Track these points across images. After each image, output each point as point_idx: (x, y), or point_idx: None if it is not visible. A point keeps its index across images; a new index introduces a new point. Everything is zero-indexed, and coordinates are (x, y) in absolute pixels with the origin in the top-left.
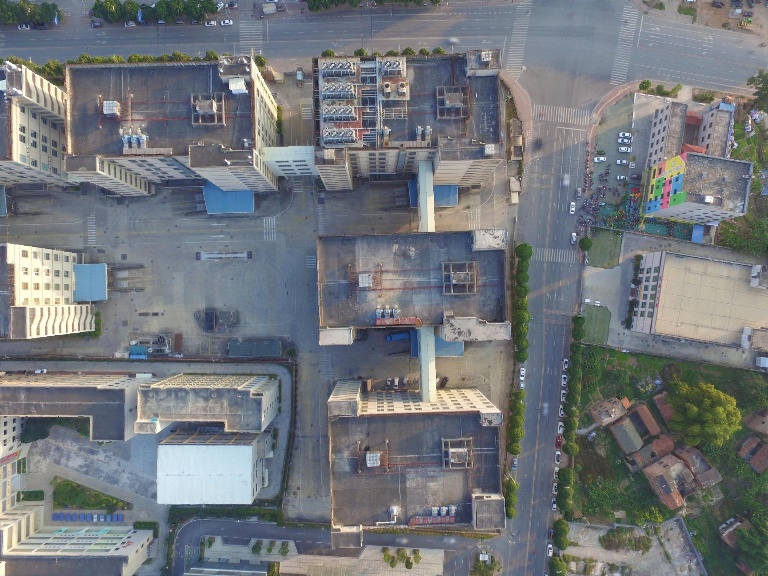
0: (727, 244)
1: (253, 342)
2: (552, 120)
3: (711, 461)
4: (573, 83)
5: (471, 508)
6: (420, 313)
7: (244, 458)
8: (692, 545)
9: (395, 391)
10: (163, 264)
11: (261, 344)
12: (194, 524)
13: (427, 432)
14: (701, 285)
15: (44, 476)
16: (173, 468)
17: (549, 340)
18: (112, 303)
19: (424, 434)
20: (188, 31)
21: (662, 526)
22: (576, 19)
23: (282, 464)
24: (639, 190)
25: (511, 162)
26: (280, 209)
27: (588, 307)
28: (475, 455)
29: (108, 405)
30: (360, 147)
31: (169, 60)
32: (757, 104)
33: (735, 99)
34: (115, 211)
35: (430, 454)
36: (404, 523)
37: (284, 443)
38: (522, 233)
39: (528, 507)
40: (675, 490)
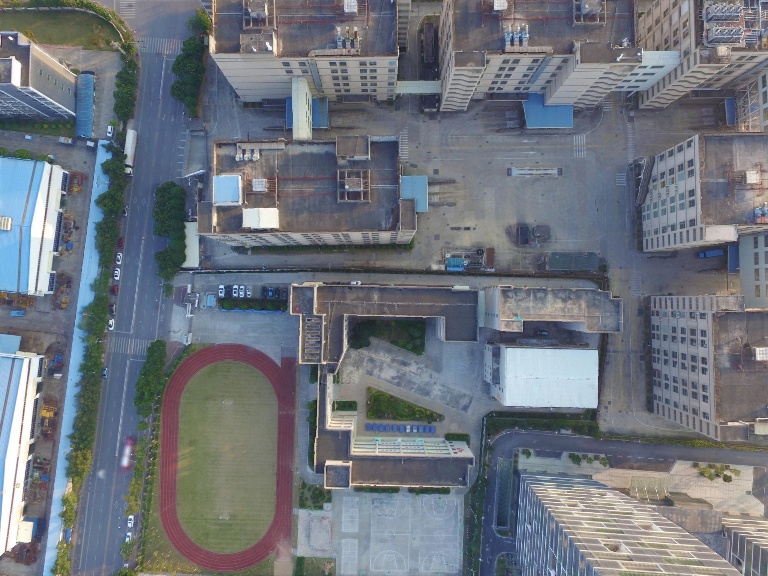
0: None
1: (572, 255)
2: None
3: None
4: None
5: None
6: None
7: (591, 362)
8: None
9: None
10: (475, 179)
11: (580, 257)
12: (507, 436)
13: None
14: None
15: (356, 387)
16: (521, 371)
17: None
18: (424, 217)
19: None
20: None
21: None
22: None
23: None
24: None
25: None
26: (590, 127)
27: None
28: None
29: (460, 307)
30: (743, 47)
31: None
32: None
33: None
34: (427, 126)
35: None
36: None
37: None
38: None
39: None
40: None
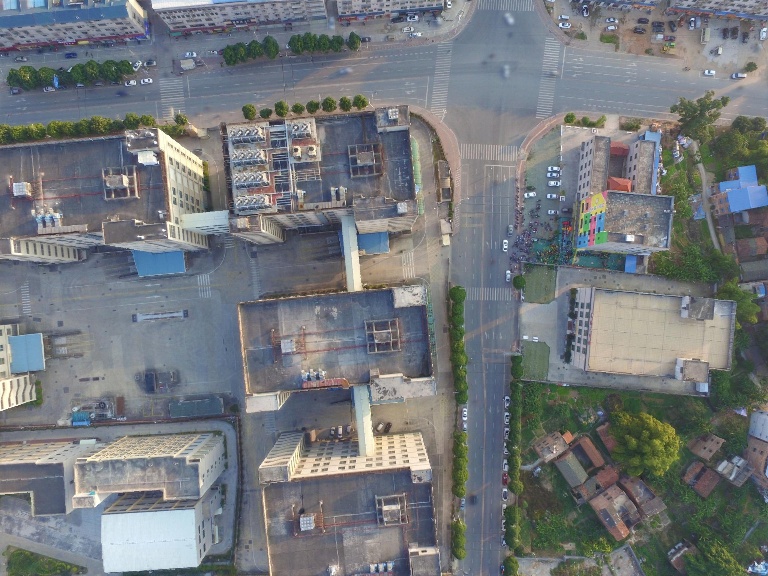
0: (660, 273)
1: (194, 402)
2: (480, 158)
3: (657, 488)
4: (499, 120)
5: (409, 562)
6: (346, 373)
7: (187, 522)
8: (642, 572)
9: (338, 441)
10: (100, 328)
11: (202, 403)
12: None
13: (361, 490)
14: (632, 319)
15: None
16: (117, 537)
17: (490, 379)
18: (52, 371)
19: (358, 493)
20: (108, 92)
21: (612, 555)
22: (498, 54)
23: (232, 519)
24: (570, 224)
25: (441, 204)
26: (213, 266)
27: (527, 343)
28: (409, 510)
29: (48, 479)
30: (274, 212)
31: (88, 125)
32: (683, 130)
33: (662, 125)
34: (48, 278)
35: (365, 512)
36: None
37: (233, 498)
38: (457, 274)
39: (479, 545)
40: (619, 522)
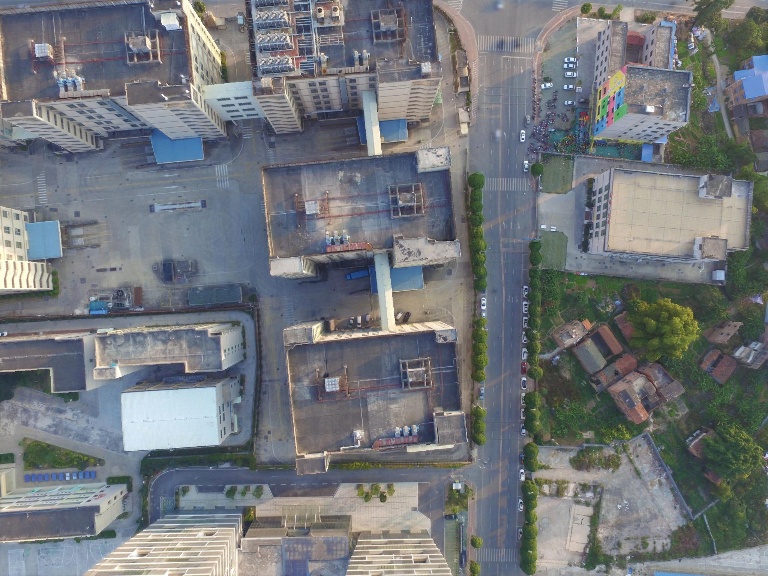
0: (677, 161)
1: (212, 289)
2: (497, 50)
3: (675, 377)
4: (515, 12)
5: (433, 427)
6: (370, 238)
7: (208, 400)
8: (661, 459)
9: (358, 328)
10: (117, 219)
11: (221, 290)
12: (167, 475)
13: (385, 355)
14: (651, 199)
15: (13, 439)
16: (138, 415)
17: (508, 268)
18: (68, 261)
19: (382, 357)
20: None
21: (630, 443)
22: None
23: (251, 410)
24: (587, 113)
25: (459, 94)
26: (231, 156)
27: (544, 233)
28: (434, 374)
29: (67, 356)
30: (298, 75)
31: None
32: (698, 20)
33: (677, 18)
34: (65, 169)
35: (389, 377)
36: (368, 446)
37: (252, 389)
38: (474, 164)
39: (498, 434)
40: (639, 404)
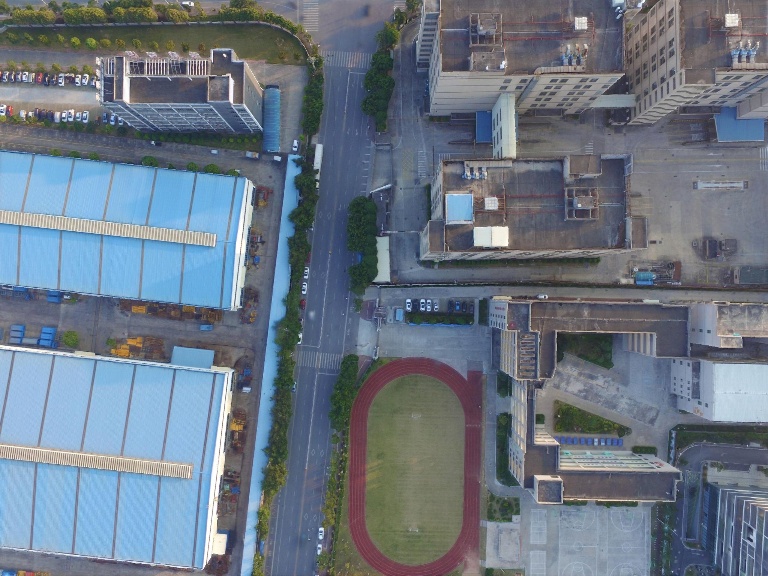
0: None
1: (763, 269)
2: None
3: None
4: None
5: None
6: None
7: None
8: None
9: None
10: (660, 193)
11: None
12: (694, 449)
13: None
14: None
15: (543, 400)
16: (730, 386)
17: None
18: None
19: None
20: None
21: None
22: None
23: None
24: None
25: None
26: None
27: None
28: None
29: (670, 323)
30: None
31: None
32: None
33: None
34: (613, 140)
35: None
36: None
37: None
38: None
39: None
40: None
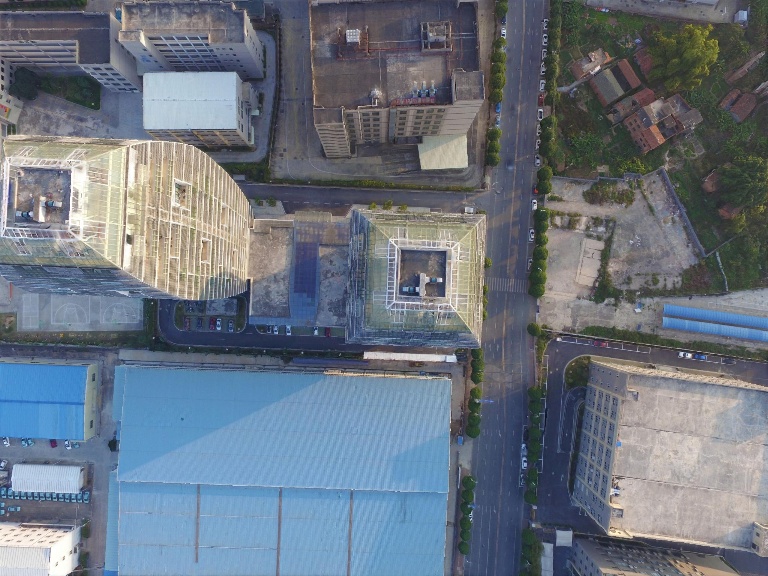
0: None
1: (237, 1)
2: None
3: None
4: None
5: (451, 91)
6: None
7: (228, 83)
8: (675, 196)
9: None
10: None
11: (245, 3)
12: None
13: (406, 19)
14: None
15: None
16: (159, 93)
17: (529, 2)
18: None
19: (403, 21)
20: None
21: (645, 179)
22: None
23: (268, 128)
24: None
25: None
26: None
27: None
28: (454, 40)
29: (93, 31)
30: None
31: None
32: None
33: None
34: None
35: (409, 40)
36: (385, 107)
37: (270, 108)
38: None
39: (512, 165)
40: None
